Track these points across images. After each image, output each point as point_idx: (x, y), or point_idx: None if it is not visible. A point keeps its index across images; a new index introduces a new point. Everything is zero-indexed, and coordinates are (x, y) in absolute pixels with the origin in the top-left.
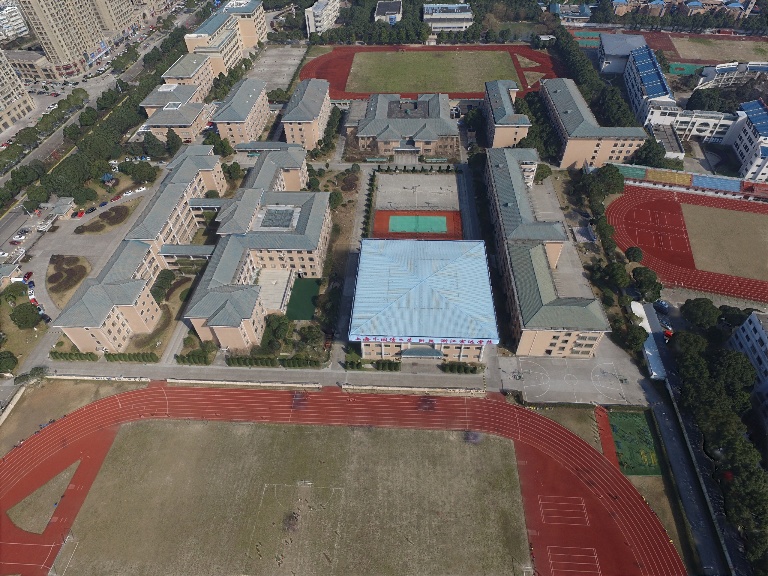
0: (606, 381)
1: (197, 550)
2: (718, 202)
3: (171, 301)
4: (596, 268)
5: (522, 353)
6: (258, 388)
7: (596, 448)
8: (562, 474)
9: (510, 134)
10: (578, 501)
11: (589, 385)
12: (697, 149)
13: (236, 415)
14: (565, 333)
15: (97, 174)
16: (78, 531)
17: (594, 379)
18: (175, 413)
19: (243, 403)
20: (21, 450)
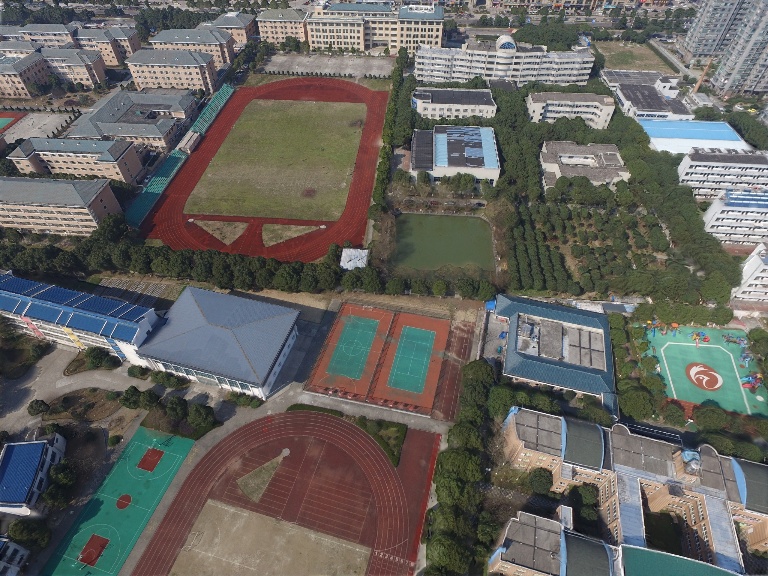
0: None
1: None
2: None
3: None
4: None
5: None
6: None
7: None
8: None
9: None
10: None
11: None
12: None
13: None
14: None
15: None
16: None
17: None
18: None
19: None
20: None
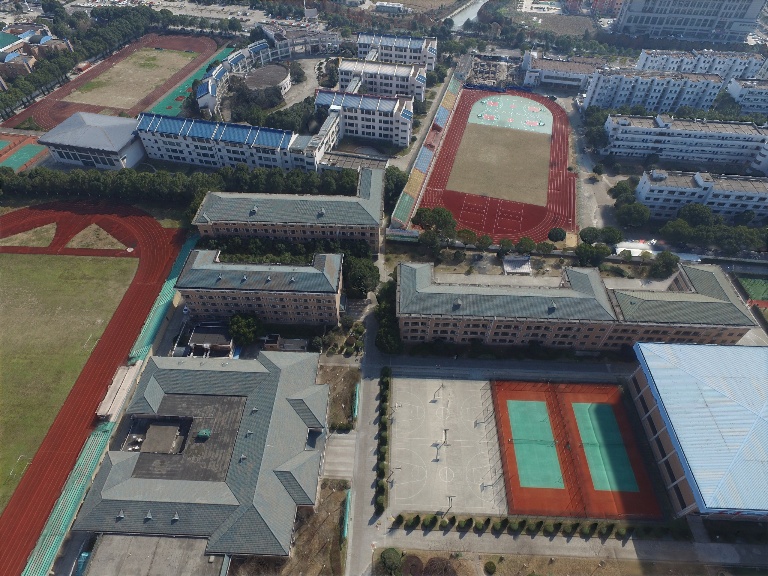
0: None
1: None
2: (442, 169)
3: None
4: None
5: None
6: None
7: None
8: None
9: None
10: None
11: None
12: None
13: None
14: None
15: None
16: None
17: None
18: None
19: None
20: None
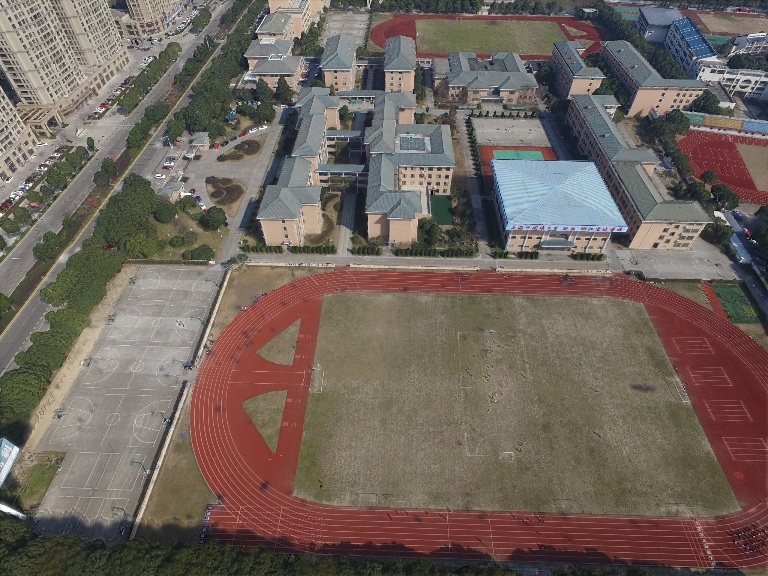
0: (704, 265)
1: (421, 373)
2: (765, 143)
3: (327, 211)
4: (679, 188)
5: (634, 246)
6: (427, 271)
7: (708, 307)
8: (686, 324)
9: (585, 85)
10: (703, 340)
11: (692, 268)
12: (740, 103)
13: (416, 289)
14: (674, 226)
15: (220, 114)
16: (320, 363)
17: (695, 264)
18: (365, 288)
19: (419, 281)
20: (248, 313)
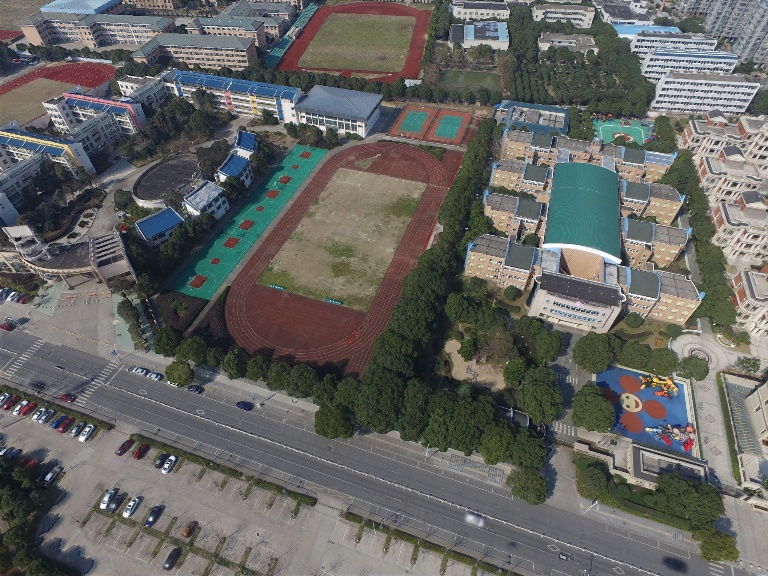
0: None
1: None
2: None
3: None
4: None
5: None
6: None
7: None
8: (0, 35)
9: None
10: None
11: None
12: None
13: None
14: None
15: None
16: None
17: None
18: None
19: None
20: None
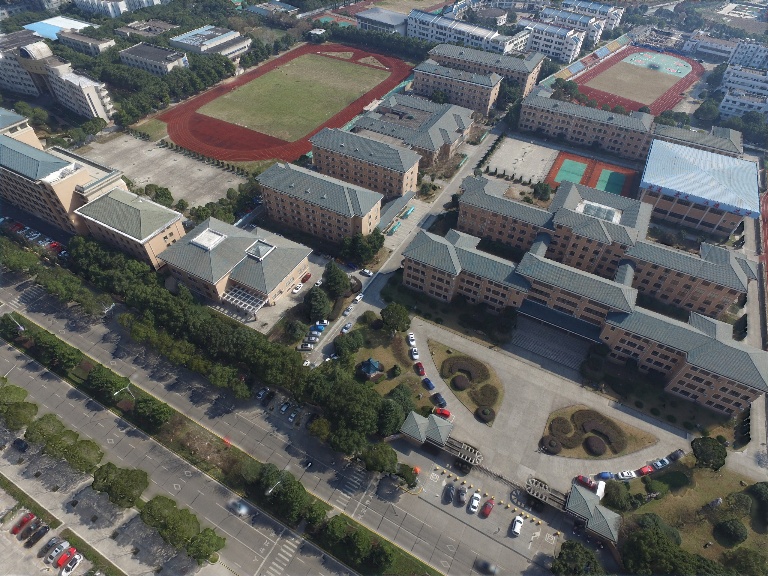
0: None
1: None
2: (587, 76)
3: None
4: None
5: None
6: (767, 295)
7: None
8: None
9: None
10: None
11: None
12: None
13: None
14: None
15: None
16: None
17: None
18: None
19: None
20: None
